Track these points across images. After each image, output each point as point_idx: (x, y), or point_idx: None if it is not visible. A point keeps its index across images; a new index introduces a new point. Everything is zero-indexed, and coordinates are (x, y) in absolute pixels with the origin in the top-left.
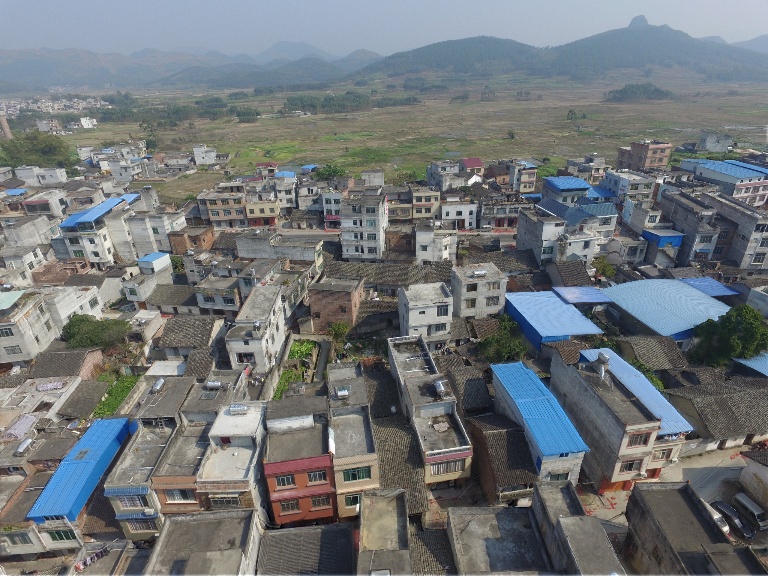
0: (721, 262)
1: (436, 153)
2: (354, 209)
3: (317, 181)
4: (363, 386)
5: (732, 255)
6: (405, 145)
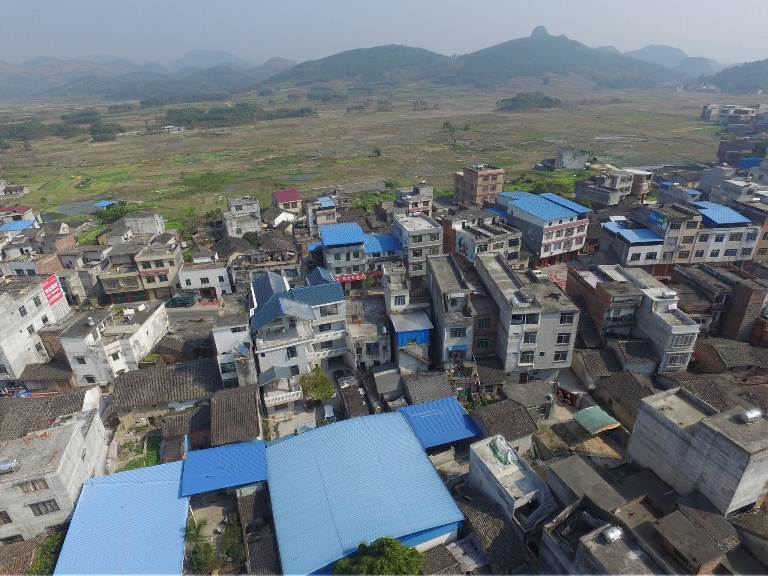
0: (482, 363)
1: (283, 177)
2: None
3: (101, 224)
4: None
5: (498, 350)
6: (257, 167)
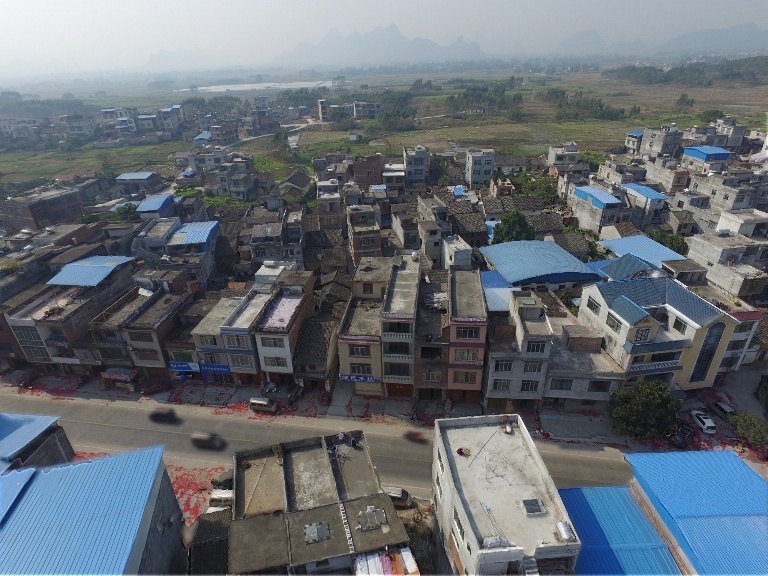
0: None
1: None
2: None
3: None
4: (721, 177)
5: None
6: None
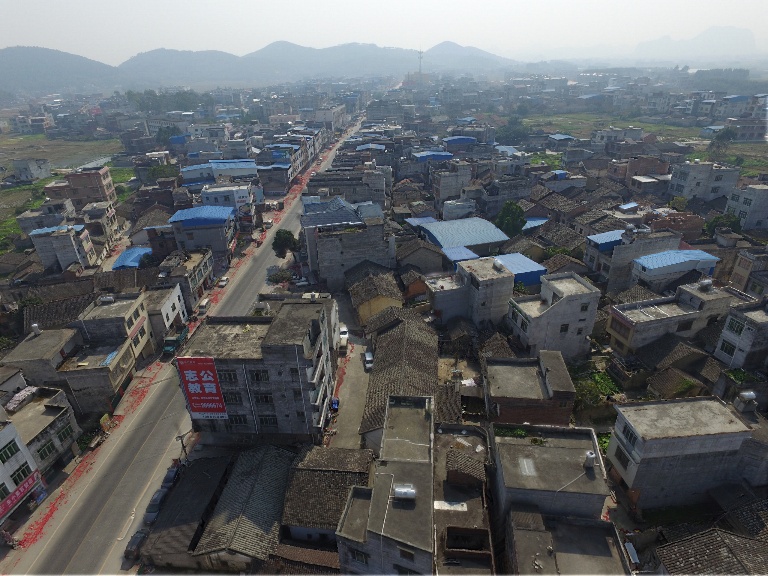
0: None
1: None
2: (308, 336)
3: None
4: None
5: None
6: None
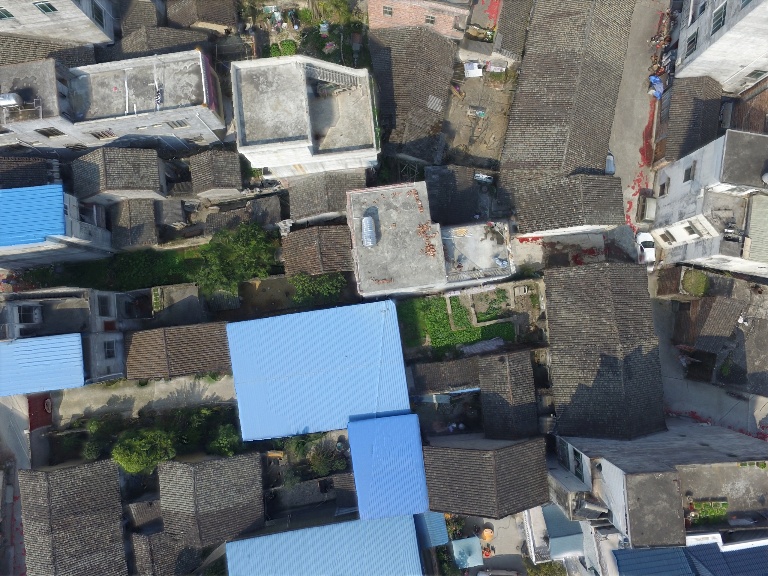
0: None
1: None
2: None
3: None
4: None
5: None
6: None
